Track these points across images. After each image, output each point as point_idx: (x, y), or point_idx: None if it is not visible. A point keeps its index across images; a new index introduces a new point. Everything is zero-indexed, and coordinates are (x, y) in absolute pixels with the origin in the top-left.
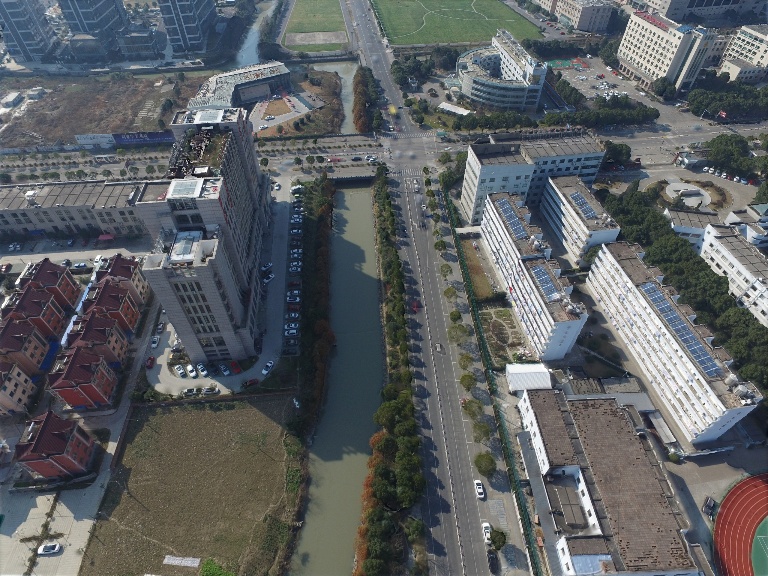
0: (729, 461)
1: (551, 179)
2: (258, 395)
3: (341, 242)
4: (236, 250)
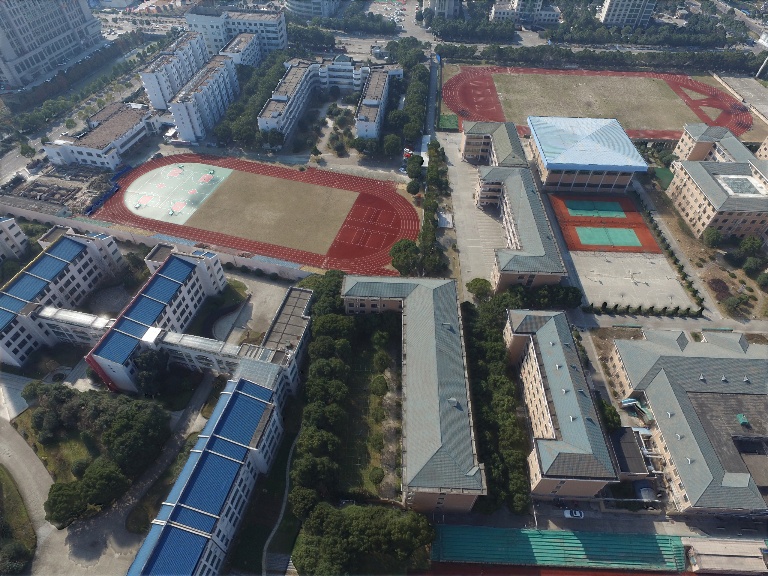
0: (191, 148)
1: (239, 33)
2: (7, 96)
3: (123, 61)
4: (14, 22)
